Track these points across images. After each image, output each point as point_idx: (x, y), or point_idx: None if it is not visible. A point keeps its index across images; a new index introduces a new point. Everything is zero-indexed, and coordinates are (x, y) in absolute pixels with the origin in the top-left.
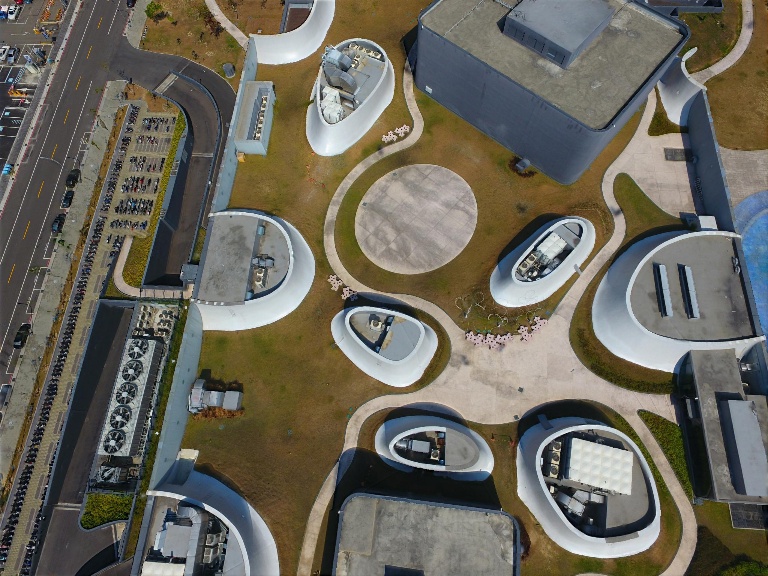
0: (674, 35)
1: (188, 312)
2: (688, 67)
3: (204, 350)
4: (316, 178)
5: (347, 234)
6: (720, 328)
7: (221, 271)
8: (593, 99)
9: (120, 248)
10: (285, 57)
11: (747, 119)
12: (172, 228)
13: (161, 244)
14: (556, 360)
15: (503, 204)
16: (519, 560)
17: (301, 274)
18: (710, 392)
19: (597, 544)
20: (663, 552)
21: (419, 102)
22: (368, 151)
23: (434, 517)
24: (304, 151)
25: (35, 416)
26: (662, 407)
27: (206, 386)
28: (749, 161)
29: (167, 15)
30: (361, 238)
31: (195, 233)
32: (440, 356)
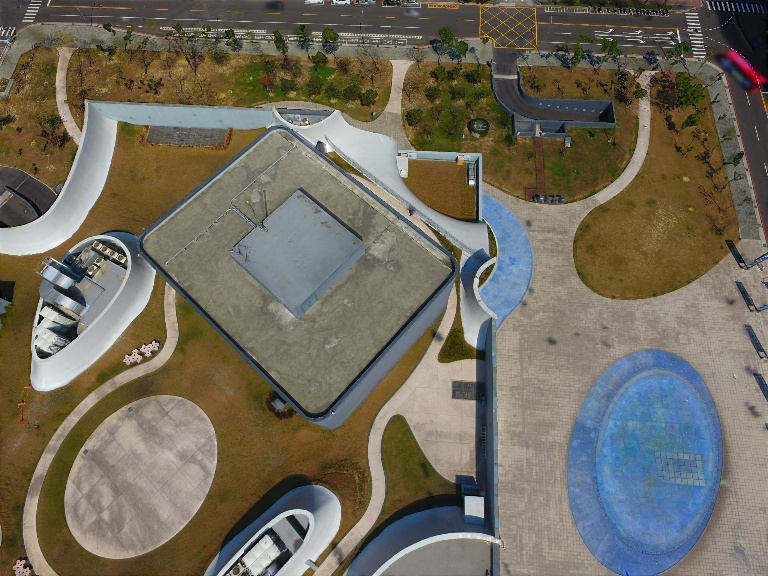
0: (441, 269)
1: None
2: (571, 194)
3: None
4: (29, 419)
5: (55, 496)
6: None
7: None
8: (322, 365)
9: None
10: (30, 247)
11: (630, 260)
12: None
13: None
14: None
15: (248, 457)
16: None
17: None
18: None
19: None
20: None
21: (179, 308)
22: (105, 376)
23: None
24: (24, 379)
25: None
26: None
27: None
28: (627, 313)
29: (13, 119)
30: (70, 502)
31: None
32: None
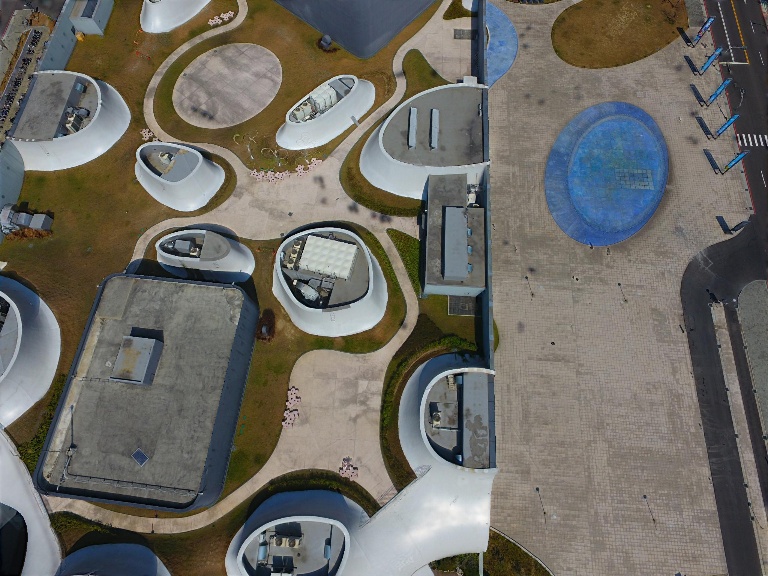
0: None
1: None
2: None
3: (25, 187)
4: (142, 52)
5: (165, 98)
6: (456, 157)
7: (37, 116)
8: None
9: None
10: None
11: (598, 41)
12: None
13: None
14: (325, 191)
15: (305, 74)
16: (241, 319)
17: (112, 123)
18: (438, 206)
19: (323, 320)
20: (385, 332)
21: None
22: (195, 32)
23: (180, 292)
24: (136, 31)
25: None
26: (408, 227)
27: (18, 210)
28: (594, 77)
29: None
30: (177, 101)
31: None
32: (225, 189)
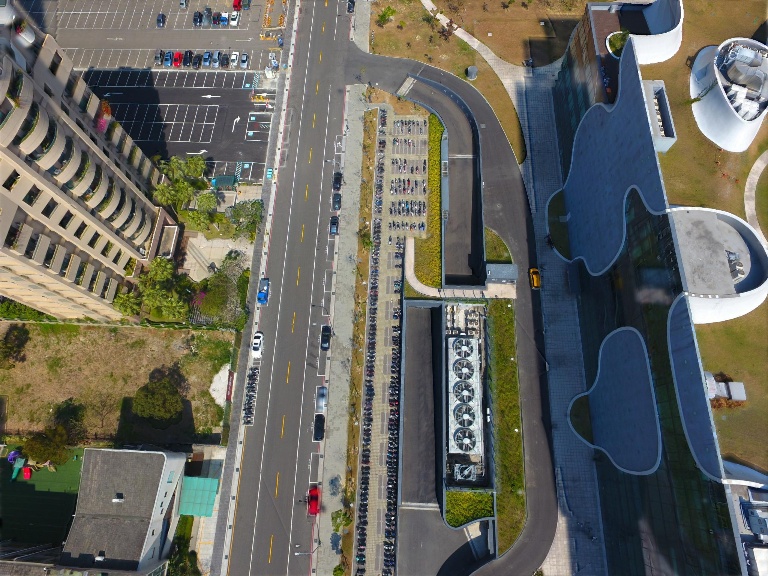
0: None
1: (687, 305)
2: None
3: None
4: (729, 174)
5: None
6: None
7: (701, 265)
8: None
9: (404, 249)
10: (654, 57)
11: None
12: None
13: None
14: None
15: None
16: None
17: None
18: None
19: None
20: None
21: None
22: (763, 147)
23: None
24: (706, 148)
25: None
26: None
27: None
28: None
29: (390, 19)
30: None
31: (483, 233)
32: None
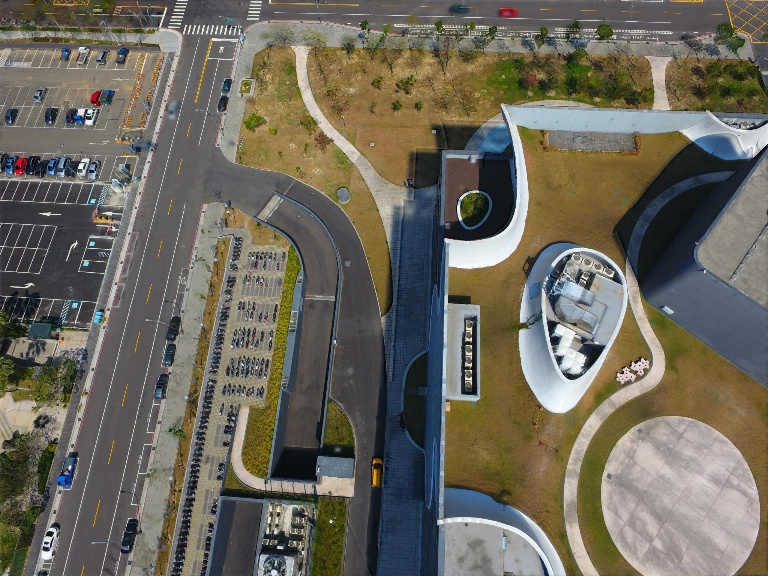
0: None
1: None
2: None
3: None
4: (547, 442)
5: (595, 523)
6: None
7: None
8: None
9: (235, 422)
10: (482, 260)
11: None
12: (291, 392)
13: (282, 416)
14: None
15: None
16: None
17: None
18: None
19: None
20: None
21: (653, 323)
22: (601, 396)
23: None
24: (525, 399)
25: None
26: None
27: None
28: None
29: (264, 121)
30: (614, 530)
31: (325, 409)
32: None
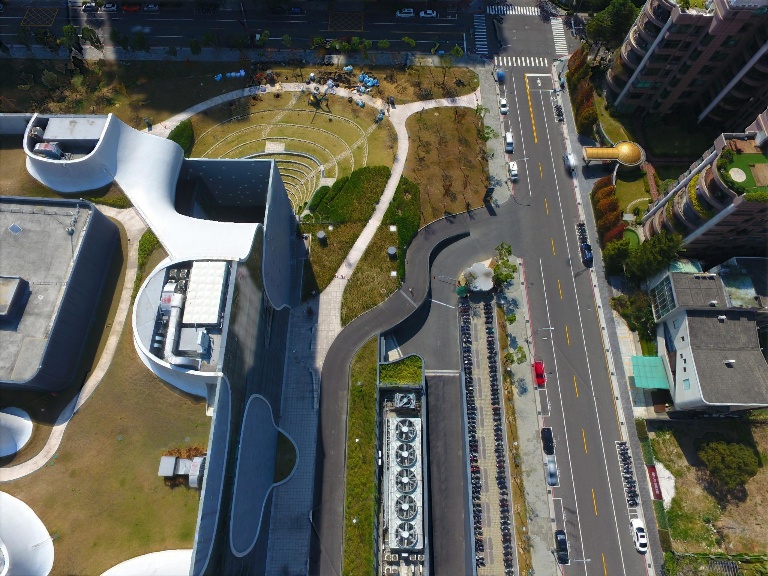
0: None
1: (194, 569)
2: None
3: None
4: None
5: None
6: None
7: None
8: None
9: None
10: None
11: None
12: None
13: None
14: None
15: None
16: None
17: None
18: None
19: None
20: None
21: None
22: None
23: None
24: None
25: (507, 453)
26: None
27: None
28: None
29: None
30: None
31: None
32: None
